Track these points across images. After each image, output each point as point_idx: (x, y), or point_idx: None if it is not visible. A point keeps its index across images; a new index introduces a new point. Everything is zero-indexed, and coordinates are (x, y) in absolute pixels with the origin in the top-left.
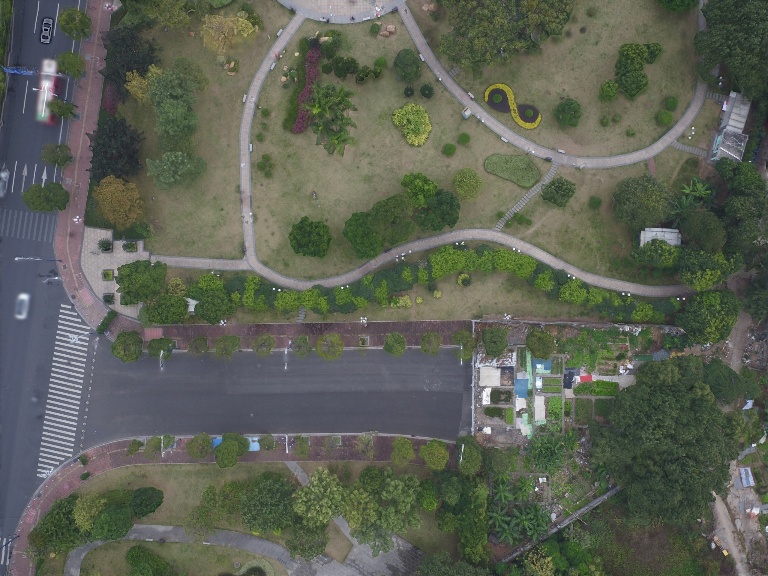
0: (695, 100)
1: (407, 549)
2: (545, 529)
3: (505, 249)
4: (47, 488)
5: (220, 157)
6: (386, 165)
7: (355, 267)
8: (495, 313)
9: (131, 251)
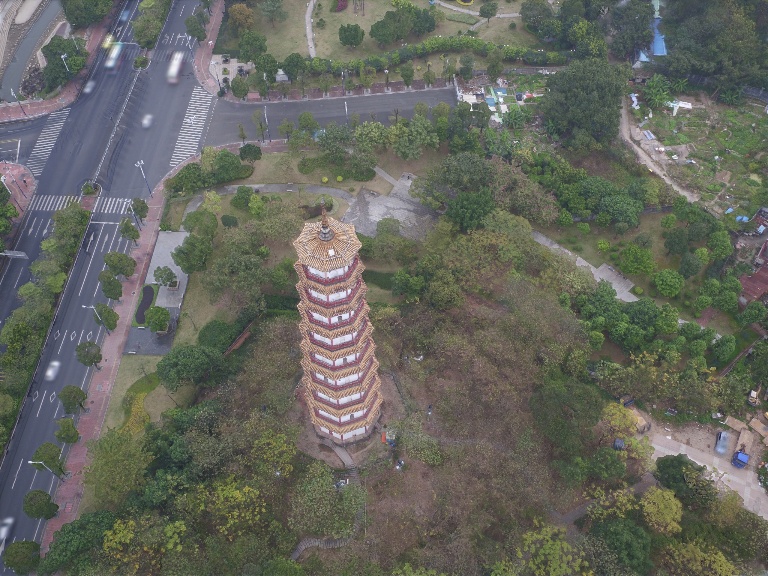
0: None
1: None
2: None
3: None
4: (176, 171)
5: (295, 24)
6: None
7: None
8: None
9: (241, 62)
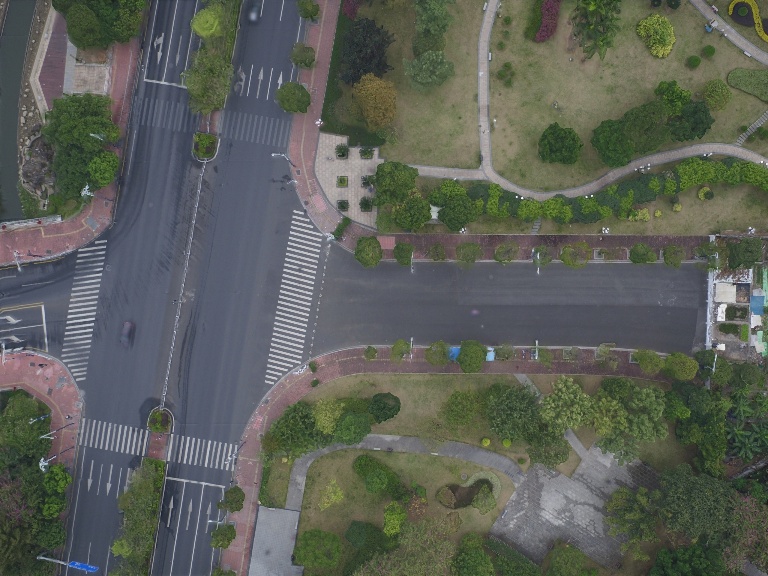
0: None
1: (636, 465)
2: None
3: (752, 162)
4: (275, 395)
5: (460, 65)
6: (629, 76)
7: (592, 179)
8: (733, 229)
9: (366, 158)
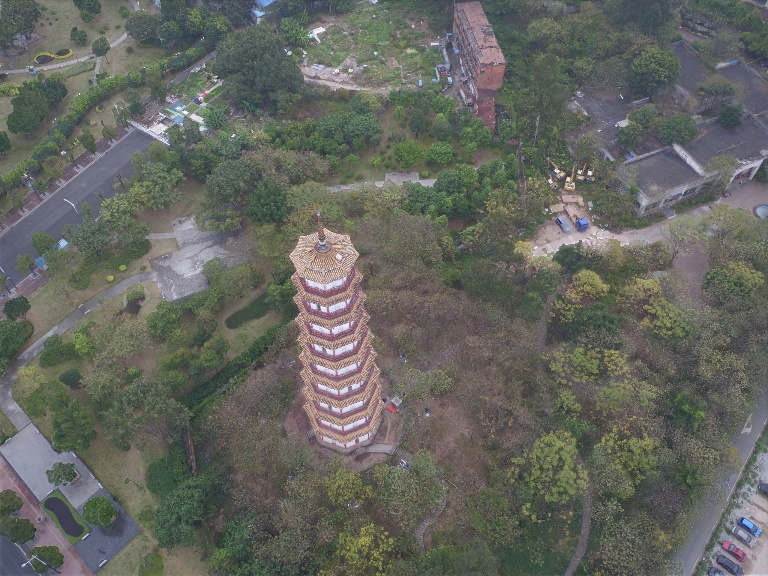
0: (133, 4)
1: None
2: None
3: None
4: None
5: None
6: (11, 108)
7: None
8: None
9: None
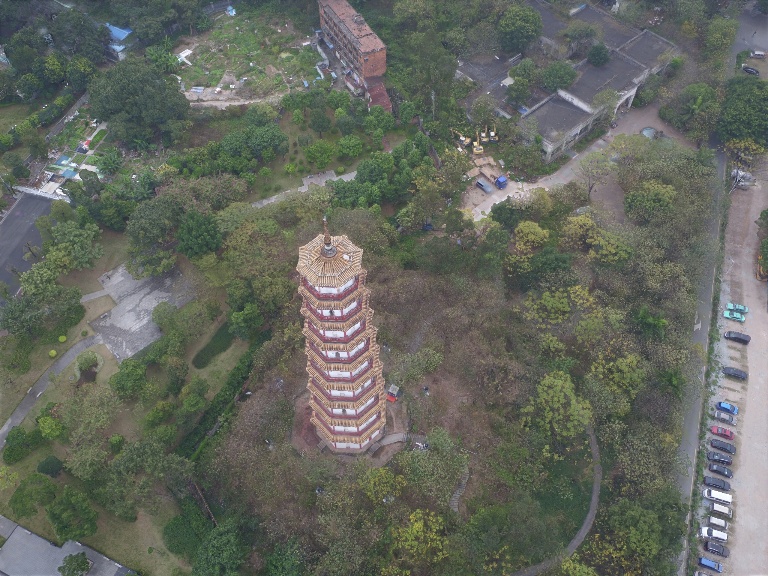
0: None
1: None
2: (155, 173)
3: None
4: None
5: None
6: None
7: None
8: None
9: None
